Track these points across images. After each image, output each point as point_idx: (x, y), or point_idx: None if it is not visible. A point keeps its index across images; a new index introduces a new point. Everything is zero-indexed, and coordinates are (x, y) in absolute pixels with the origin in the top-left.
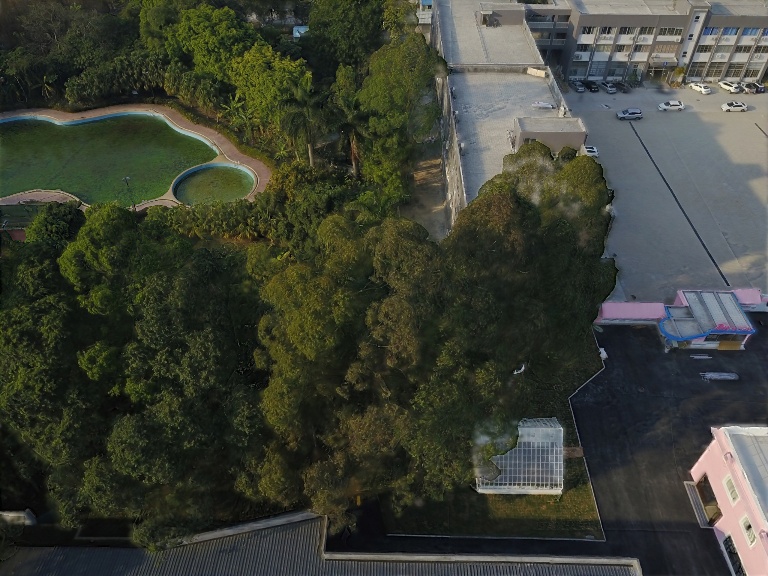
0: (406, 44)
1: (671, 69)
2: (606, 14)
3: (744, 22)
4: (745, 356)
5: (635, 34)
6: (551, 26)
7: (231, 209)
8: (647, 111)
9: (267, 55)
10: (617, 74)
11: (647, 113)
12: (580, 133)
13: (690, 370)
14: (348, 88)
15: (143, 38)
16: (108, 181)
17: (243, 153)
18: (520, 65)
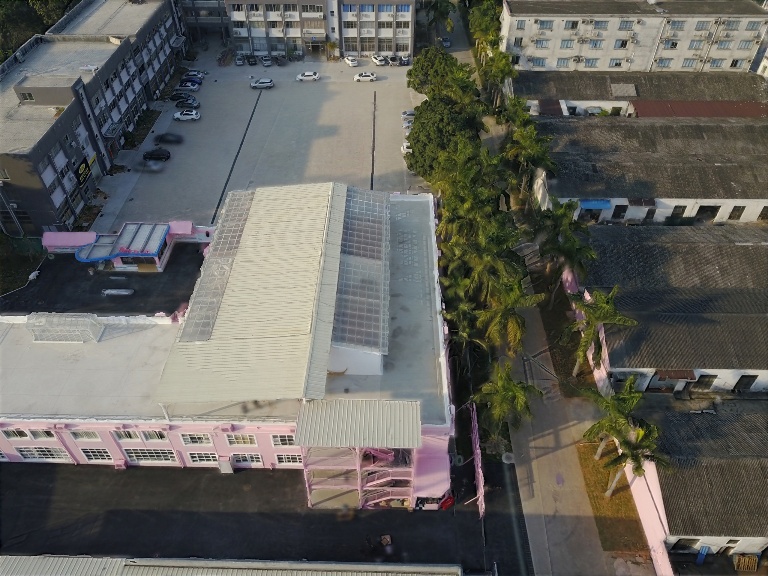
0: None
1: (325, 44)
2: None
3: None
4: (158, 277)
5: (281, 11)
6: (216, 5)
7: None
8: (285, 81)
9: None
10: (280, 49)
11: (284, 83)
12: (65, 88)
13: (98, 288)
14: None
15: None
16: None
17: None
18: None
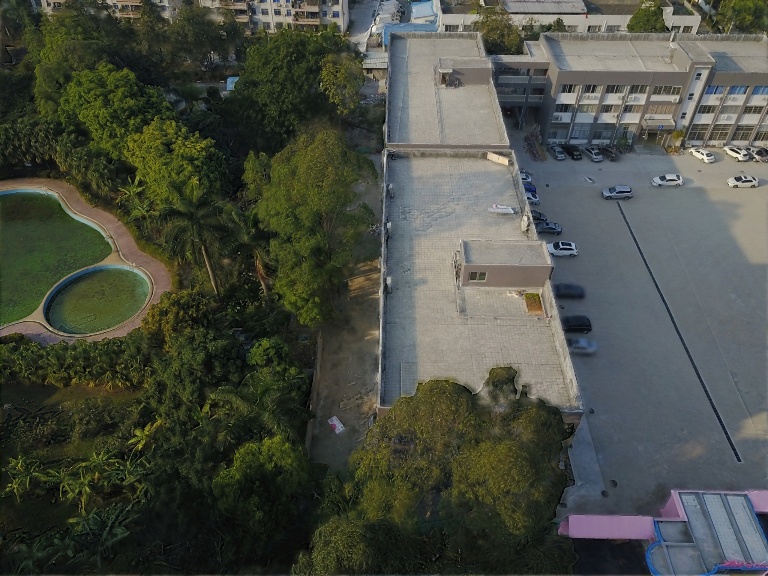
0: (315, 147)
1: (668, 132)
2: (590, 71)
3: (755, 80)
4: None
5: (625, 93)
6: (526, 81)
7: (94, 354)
8: (639, 187)
9: (169, 132)
10: (604, 137)
11: (639, 189)
12: (543, 267)
13: None
14: (259, 183)
15: (37, 99)
16: None
17: (142, 250)
18: (478, 149)
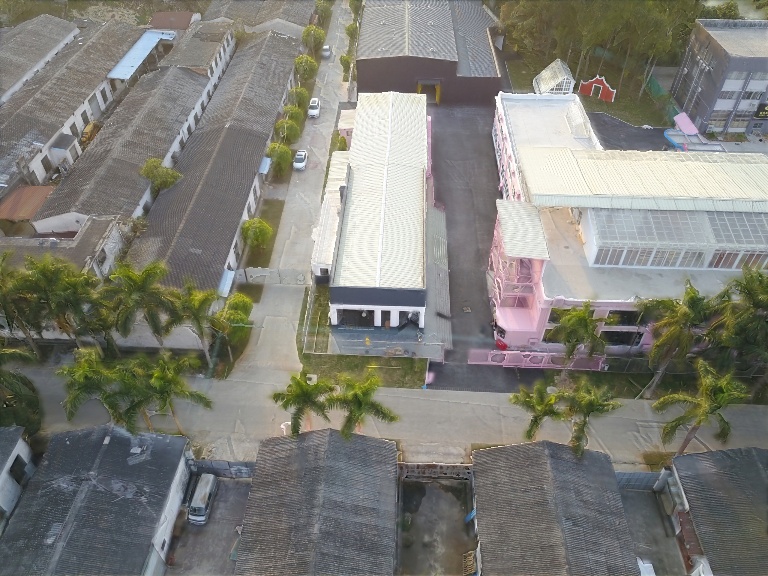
0: None
1: None
2: None
3: None
4: None
5: None
6: None
7: None
8: None
9: None
10: None
11: None
12: None
13: None
14: None
15: None
16: (710, 3)
17: None
18: None
